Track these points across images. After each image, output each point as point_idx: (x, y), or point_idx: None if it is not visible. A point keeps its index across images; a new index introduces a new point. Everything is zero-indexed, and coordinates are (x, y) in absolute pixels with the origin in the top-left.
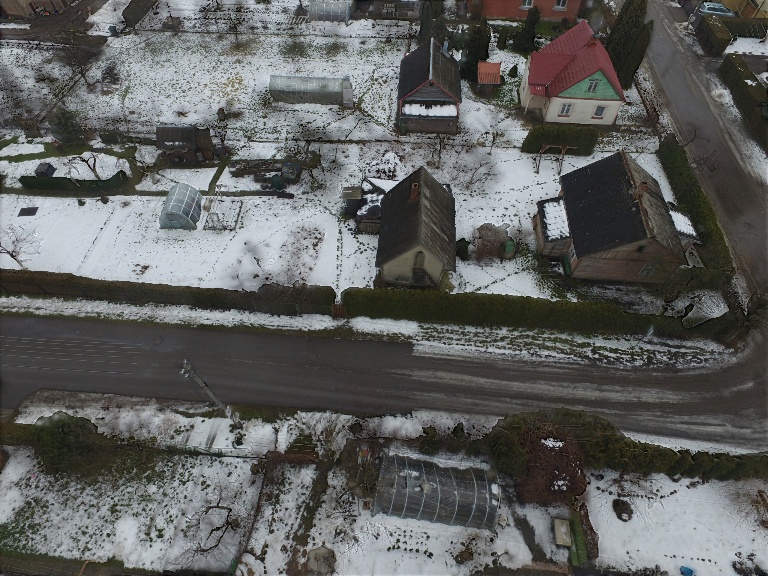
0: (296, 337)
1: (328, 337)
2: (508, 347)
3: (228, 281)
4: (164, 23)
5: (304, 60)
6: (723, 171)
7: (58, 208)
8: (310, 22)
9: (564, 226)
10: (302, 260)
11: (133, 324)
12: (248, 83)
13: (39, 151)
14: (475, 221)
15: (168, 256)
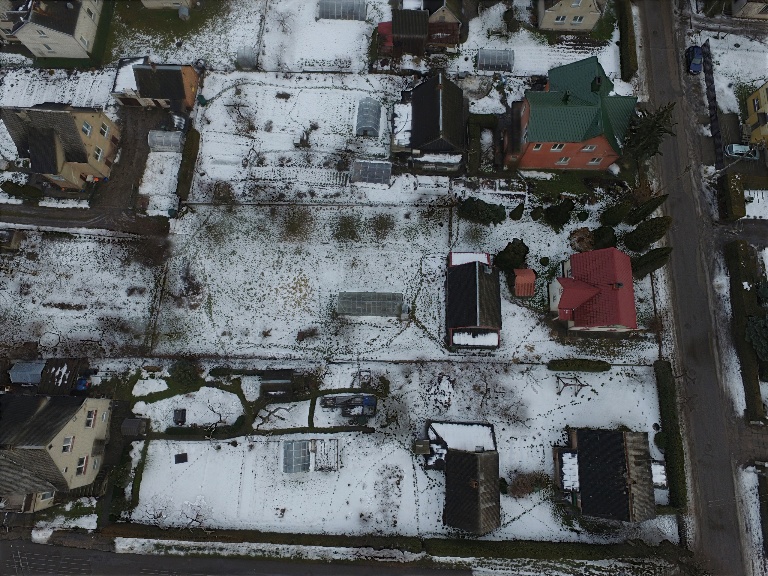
0: (397, 568)
1: (417, 567)
2: (532, 570)
3: (343, 520)
4: (216, 194)
5: (357, 246)
6: (703, 385)
7: (202, 453)
8: (354, 182)
9: (576, 481)
10: (391, 501)
11: (289, 562)
12: (313, 285)
13: (164, 389)
14: (511, 453)
15: (296, 499)
